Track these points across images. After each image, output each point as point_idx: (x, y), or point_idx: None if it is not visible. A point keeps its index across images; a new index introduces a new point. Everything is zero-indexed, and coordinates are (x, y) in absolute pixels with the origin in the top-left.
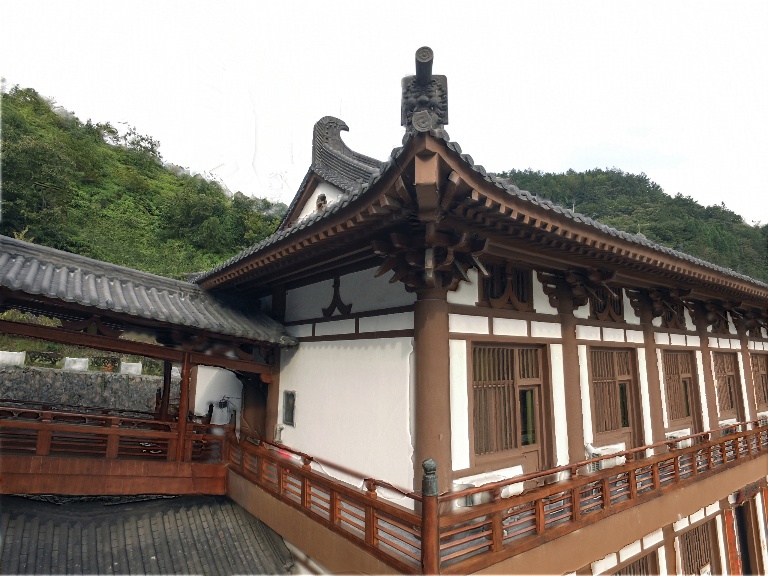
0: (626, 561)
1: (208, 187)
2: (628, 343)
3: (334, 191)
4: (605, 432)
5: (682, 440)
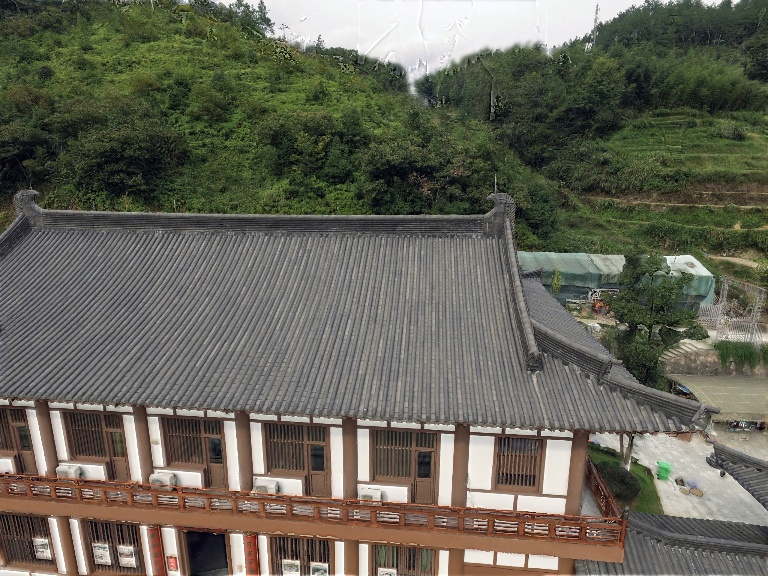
0: (11, 513)
1: (322, 90)
2: (13, 406)
3: None
4: (0, 450)
5: (60, 472)
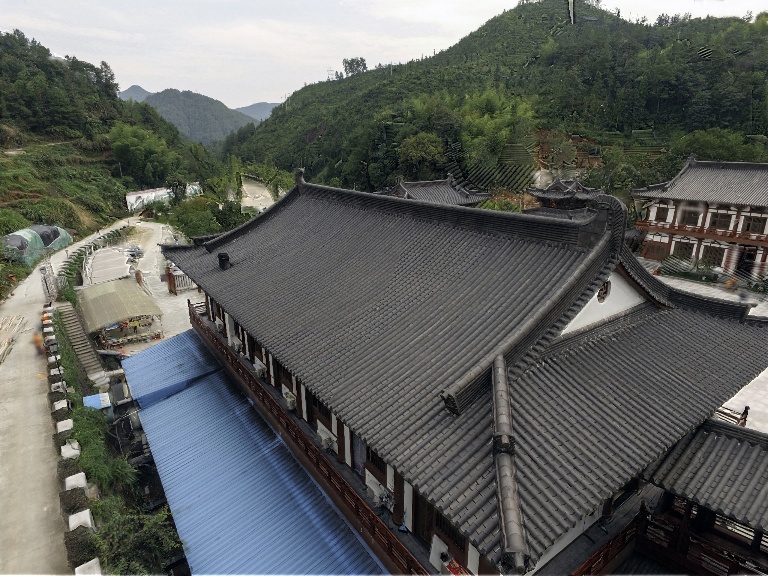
0: None
1: None
2: None
3: (622, 282)
4: None
5: None
